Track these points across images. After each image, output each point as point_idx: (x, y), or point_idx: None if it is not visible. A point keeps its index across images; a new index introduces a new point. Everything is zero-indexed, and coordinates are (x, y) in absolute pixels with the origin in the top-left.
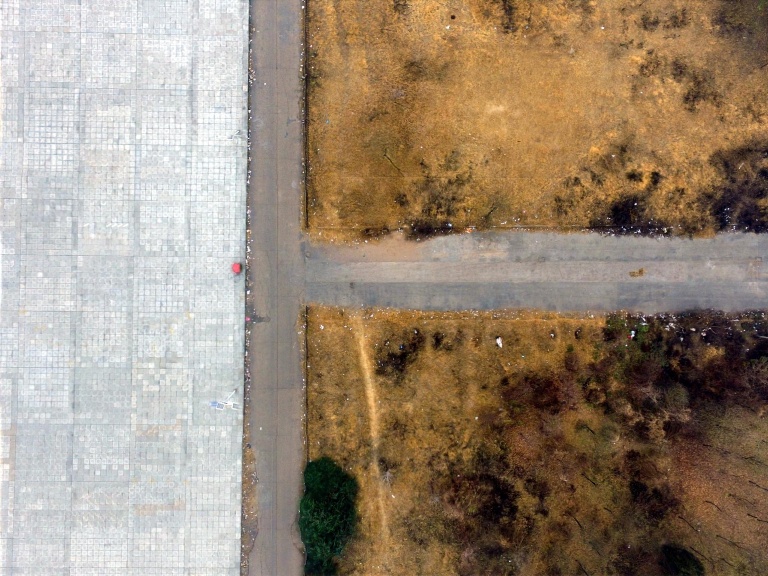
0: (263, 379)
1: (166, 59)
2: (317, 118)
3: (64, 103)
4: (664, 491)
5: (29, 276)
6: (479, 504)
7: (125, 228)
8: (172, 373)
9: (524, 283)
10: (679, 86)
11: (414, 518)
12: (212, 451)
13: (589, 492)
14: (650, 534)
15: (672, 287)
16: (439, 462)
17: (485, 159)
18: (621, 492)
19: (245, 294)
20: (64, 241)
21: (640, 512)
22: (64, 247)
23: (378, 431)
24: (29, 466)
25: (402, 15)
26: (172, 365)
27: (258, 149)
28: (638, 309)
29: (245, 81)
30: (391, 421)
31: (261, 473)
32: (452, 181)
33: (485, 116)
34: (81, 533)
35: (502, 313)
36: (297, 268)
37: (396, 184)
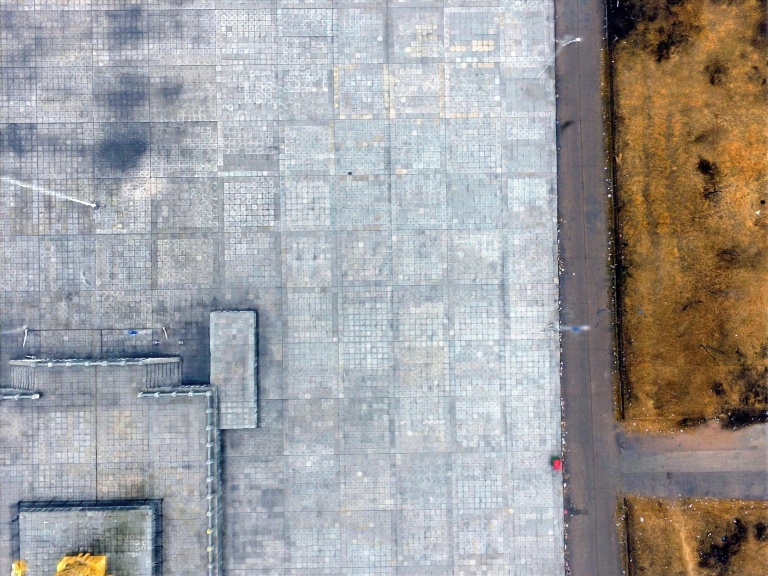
0: (583, 572)
1: (477, 254)
2: (630, 308)
3: (377, 301)
4: None
5: (349, 476)
6: None
7: (441, 424)
8: (493, 569)
9: None
10: None
11: None
12: None
13: None
14: None
15: None
16: None
17: None
18: None
19: (563, 487)
20: (382, 439)
21: None
22: (382, 445)
23: None
24: None
25: (712, 202)
26: (493, 561)
27: (569, 340)
28: None
29: (556, 273)
30: None
31: None
32: None
33: None
34: None
35: None
36: (612, 459)
37: (712, 373)
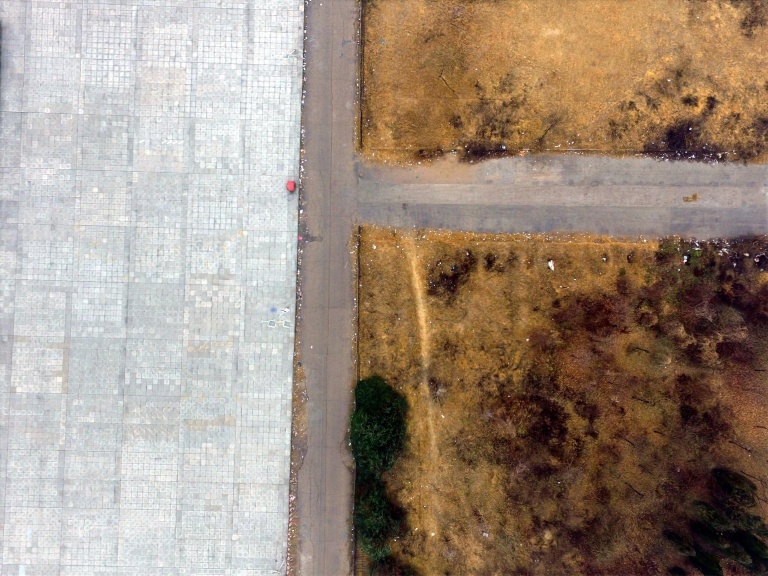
0: (315, 298)
1: None
2: (373, 39)
3: (122, 20)
4: (715, 416)
5: (84, 191)
6: (529, 425)
7: (180, 145)
8: (224, 290)
9: (577, 207)
10: (736, 11)
11: (463, 438)
12: (263, 368)
13: (639, 415)
14: (700, 458)
15: (725, 213)
16: (489, 383)
17: (540, 82)
18: (672, 416)
19: (298, 213)
20: (120, 157)
21: (690, 436)
22: (119, 163)
23: (429, 351)
24: (82, 379)
25: None
26: (225, 282)
27: (313, 69)
28: (691, 234)
29: (301, 1)
30: (442, 341)
31: (311, 391)
32: (506, 103)
33: (540, 39)
34: (132, 446)
35: (554, 236)
36: (350, 188)
37: (450, 105)
